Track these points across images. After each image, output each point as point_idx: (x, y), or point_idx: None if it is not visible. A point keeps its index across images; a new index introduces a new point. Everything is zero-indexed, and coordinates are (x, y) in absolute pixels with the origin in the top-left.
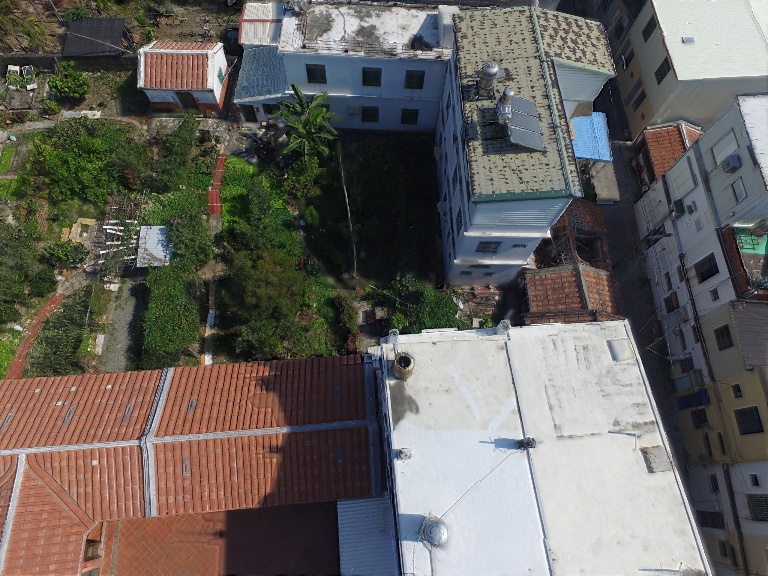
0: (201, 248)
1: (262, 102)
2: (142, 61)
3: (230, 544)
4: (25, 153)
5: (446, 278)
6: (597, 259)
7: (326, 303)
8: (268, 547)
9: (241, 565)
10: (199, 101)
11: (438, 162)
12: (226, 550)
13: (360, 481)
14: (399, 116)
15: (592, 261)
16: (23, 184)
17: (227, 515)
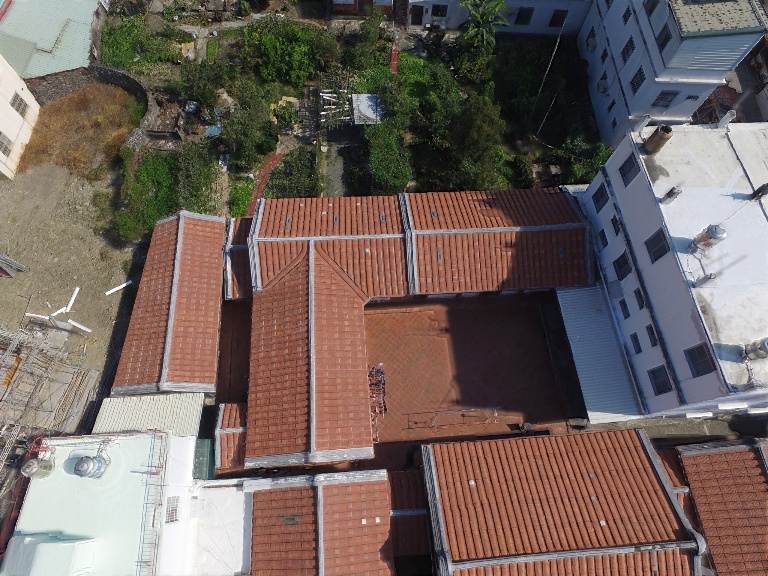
0: (409, 108)
1: (434, 3)
2: None
3: (455, 337)
4: (227, 46)
5: (605, 146)
6: None
7: (505, 164)
8: (486, 340)
9: (467, 352)
10: (376, 3)
11: (587, 55)
12: (452, 341)
13: (578, 272)
14: (549, 18)
15: None
16: (231, 69)
17: (449, 317)
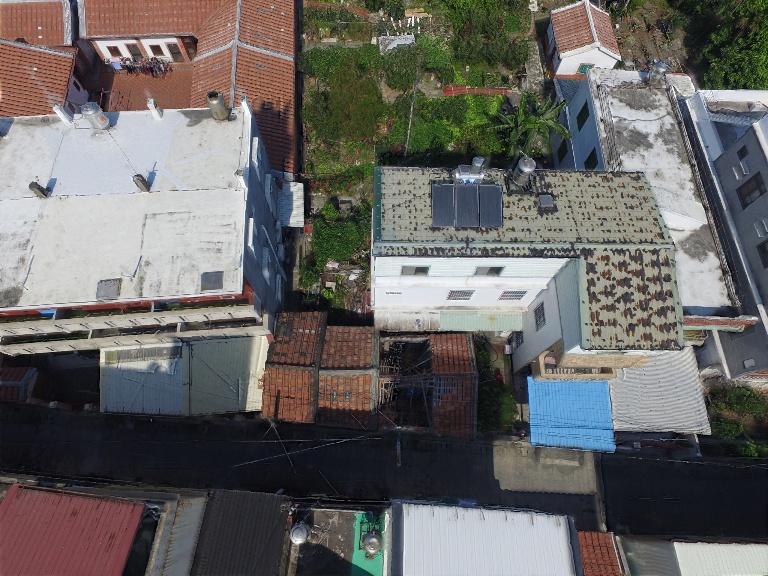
0: None
1: None
2: (576, 4)
3: None
4: None
5: None
6: (401, 421)
7: (358, 171)
8: None
9: None
10: (554, 60)
11: None
12: None
13: None
14: None
15: (399, 414)
16: None
17: None
